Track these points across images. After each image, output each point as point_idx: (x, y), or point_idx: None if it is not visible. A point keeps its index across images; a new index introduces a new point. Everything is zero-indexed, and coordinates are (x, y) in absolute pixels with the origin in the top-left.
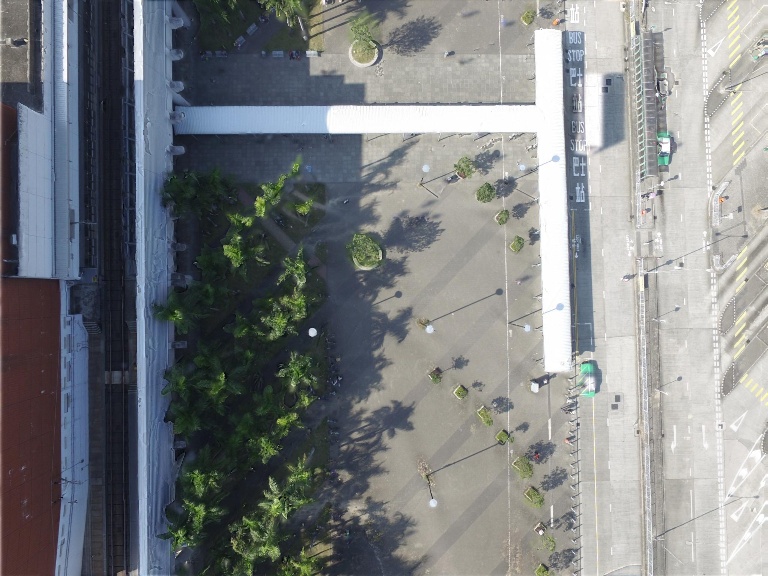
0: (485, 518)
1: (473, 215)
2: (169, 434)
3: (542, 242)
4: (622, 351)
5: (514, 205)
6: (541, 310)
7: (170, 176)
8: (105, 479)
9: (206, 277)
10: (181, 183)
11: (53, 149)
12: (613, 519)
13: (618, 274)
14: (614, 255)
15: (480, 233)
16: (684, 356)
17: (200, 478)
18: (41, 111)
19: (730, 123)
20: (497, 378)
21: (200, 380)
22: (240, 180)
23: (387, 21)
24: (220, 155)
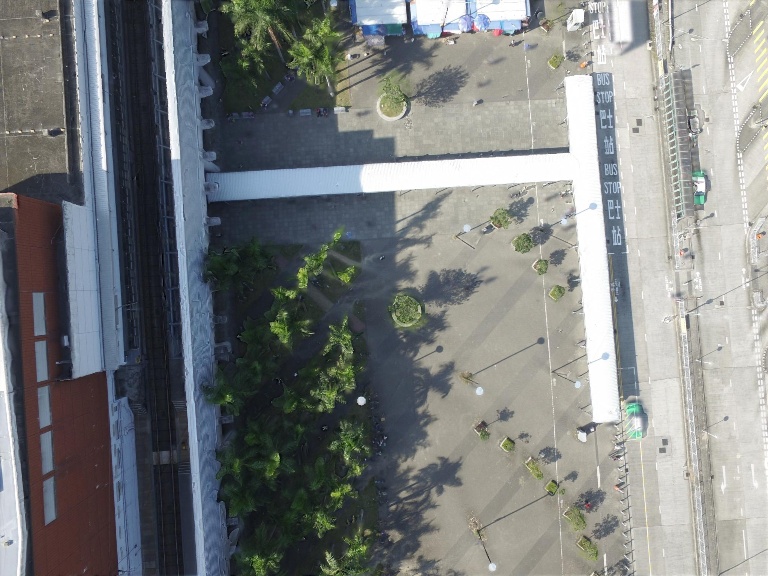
0: (538, 571)
1: (510, 264)
2: (215, 504)
3: (584, 291)
4: (667, 394)
5: (551, 252)
6: (584, 357)
7: (203, 242)
8: (158, 562)
9: (252, 352)
10: (223, 260)
11: (96, 239)
12: (667, 564)
13: (659, 316)
14: (654, 297)
15: (518, 282)
16: (729, 395)
17: (260, 563)
18: (82, 201)
19: (763, 158)
20: (543, 428)
21: (253, 460)
22: (274, 242)
23: (413, 72)
24: (252, 217)
